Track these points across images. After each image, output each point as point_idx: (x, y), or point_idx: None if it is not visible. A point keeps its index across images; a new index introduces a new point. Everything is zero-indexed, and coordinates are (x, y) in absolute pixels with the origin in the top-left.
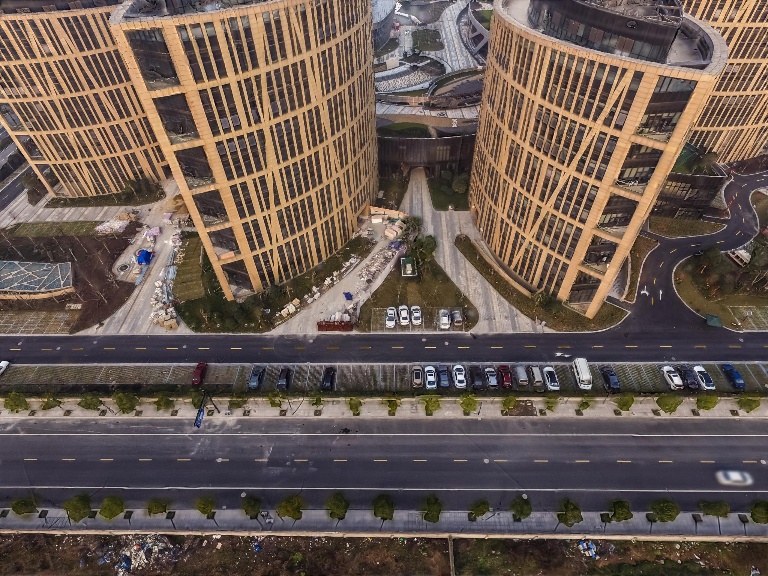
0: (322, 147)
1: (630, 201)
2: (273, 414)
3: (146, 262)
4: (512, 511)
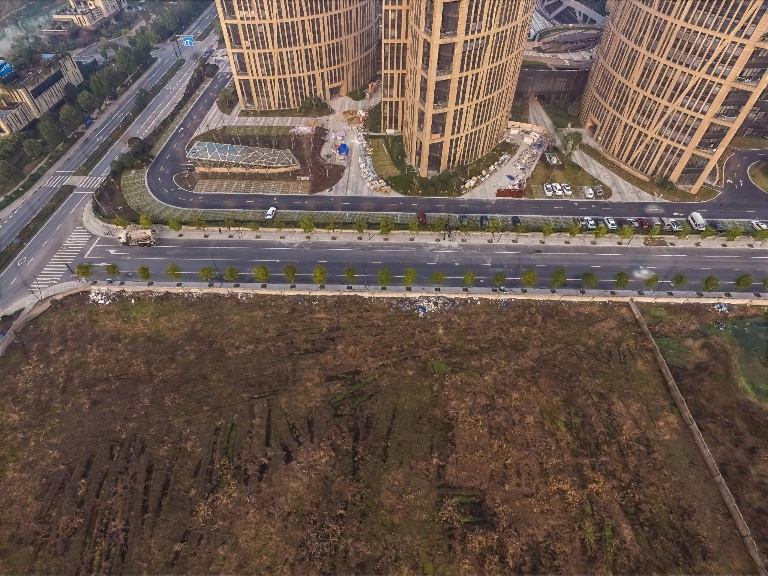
0: (510, 58)
1: (742, 96)
2: (483, 241)
3: (346, 152)
4: (666, 291)
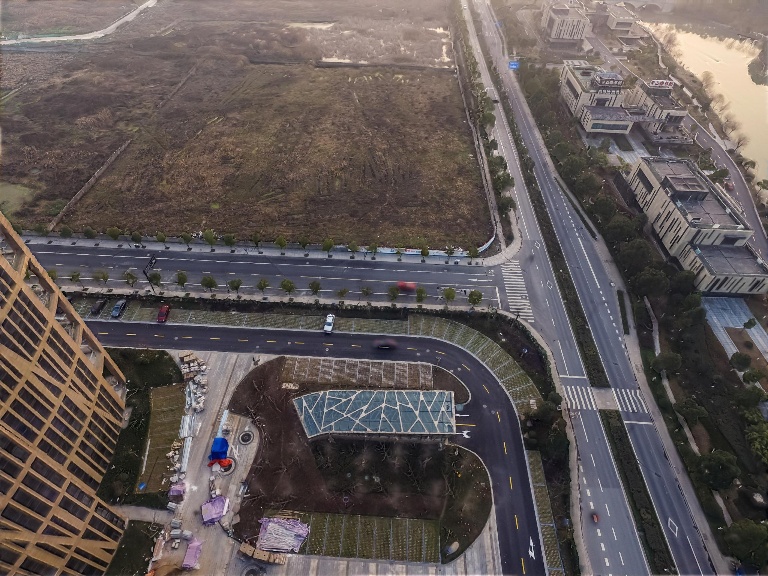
0: None
1: None
2: (117, 290)
3: None
4: None
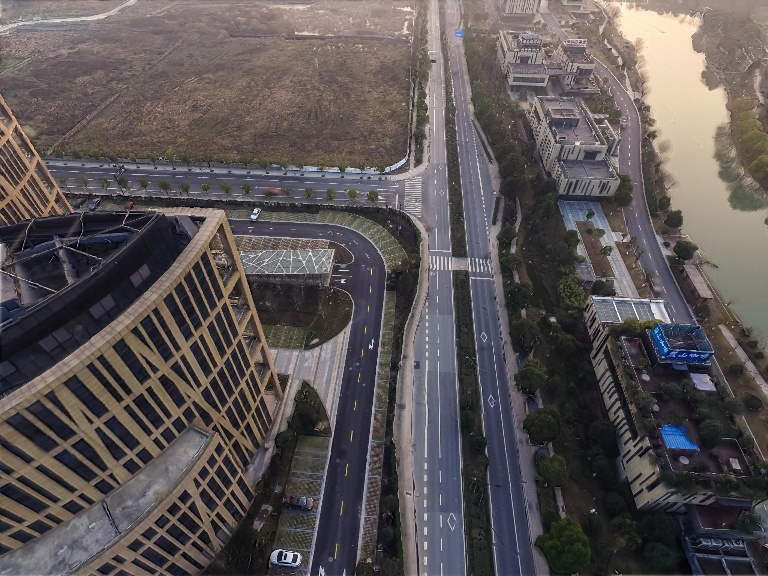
0: None
1: None
2: None
3: None
4: None
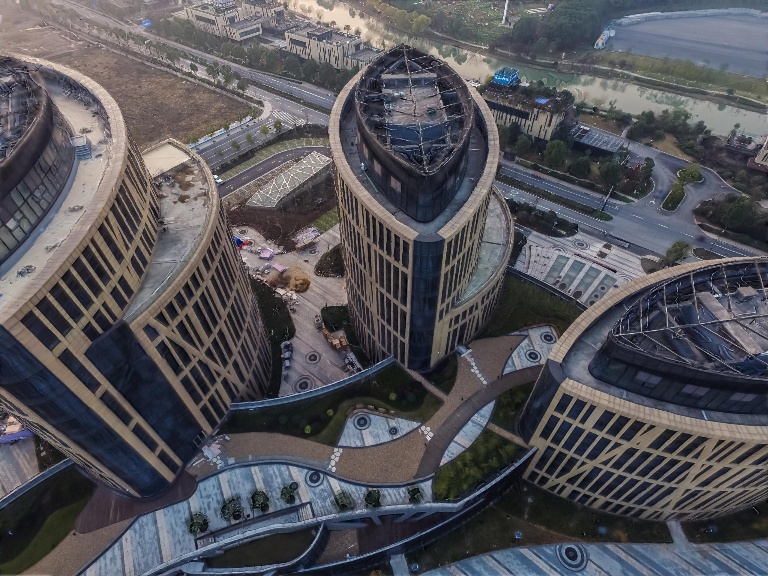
0: None
1: None
2: None
3: None
4: None
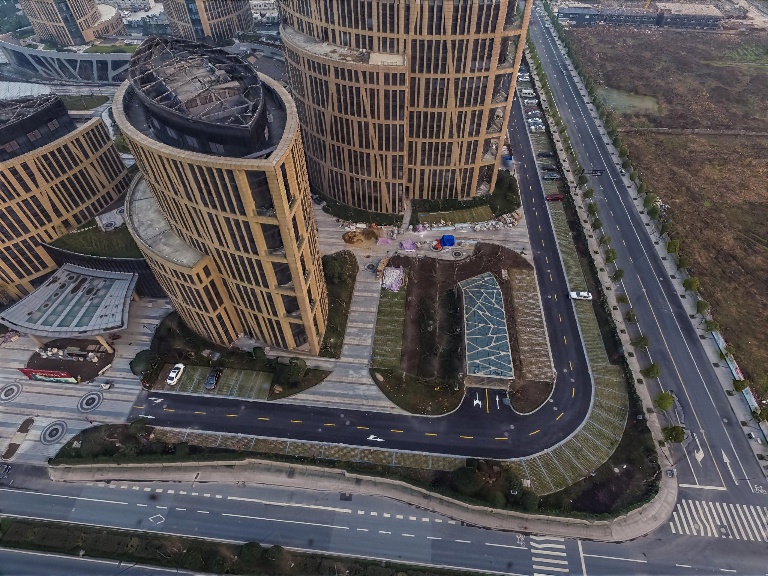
0: None
1: None
2: (570, 174)
3: None
4: None
